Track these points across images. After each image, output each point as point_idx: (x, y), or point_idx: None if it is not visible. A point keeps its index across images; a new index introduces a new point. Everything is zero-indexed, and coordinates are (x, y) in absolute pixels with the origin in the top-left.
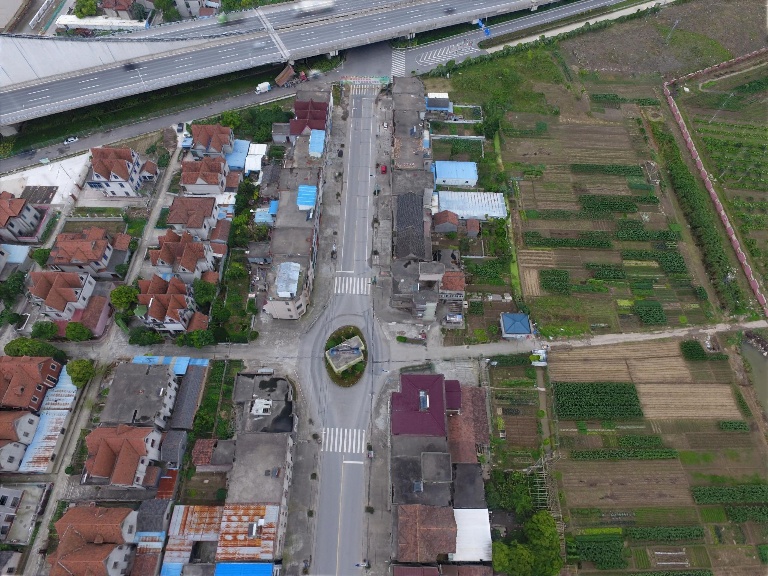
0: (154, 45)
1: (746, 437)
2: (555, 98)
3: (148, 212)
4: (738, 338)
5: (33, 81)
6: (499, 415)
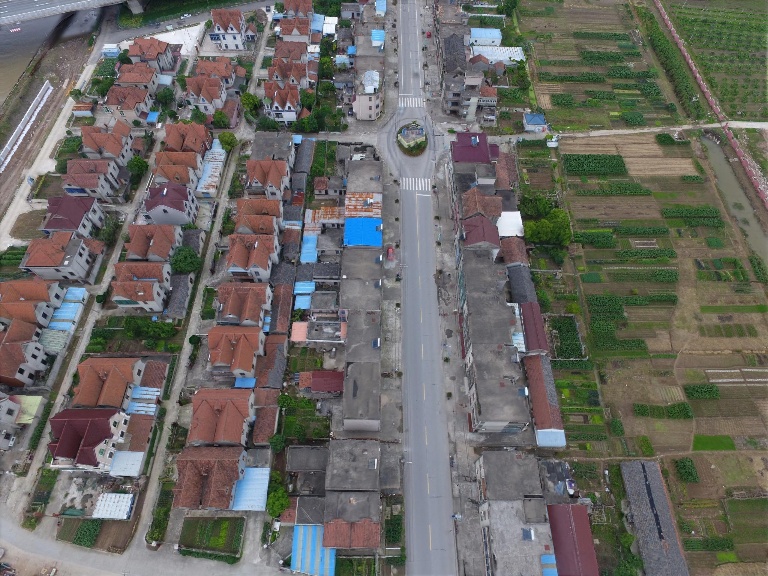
0: None
1: (701, 185)
2: None
3: (254, 59)
4: (698, 133)
5: None
6: (524, 172)
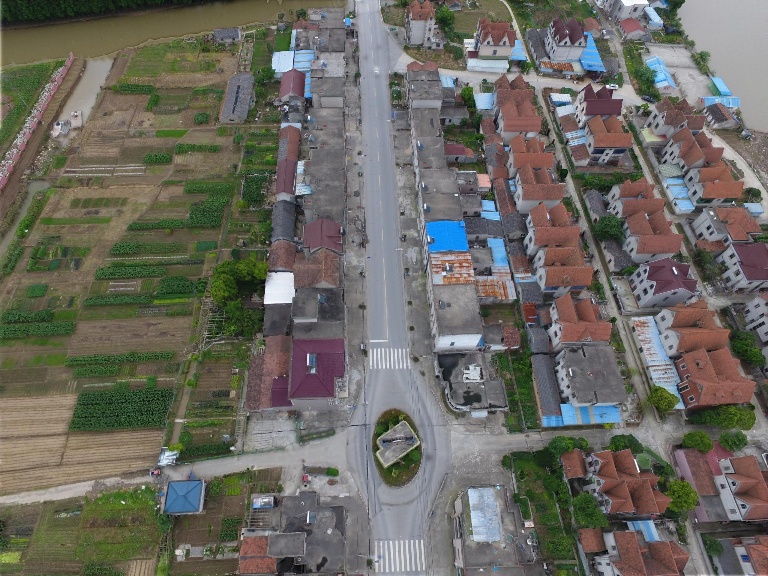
0: None
1: None
2: None
3: None
4: None
5: None
6: (234, 390)
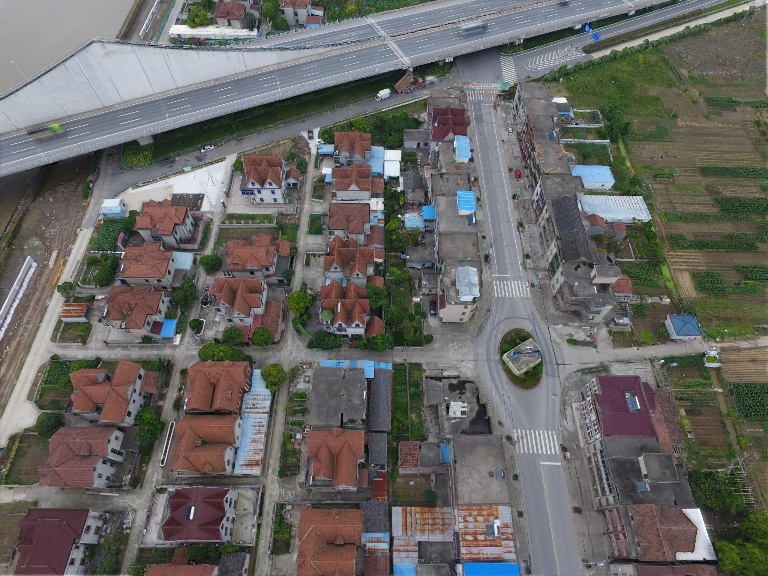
0: (283, 54)
1: None
2: (671, 101)
3: (298, 218)
4: None
5: (172, 91)
6: (683, 416)
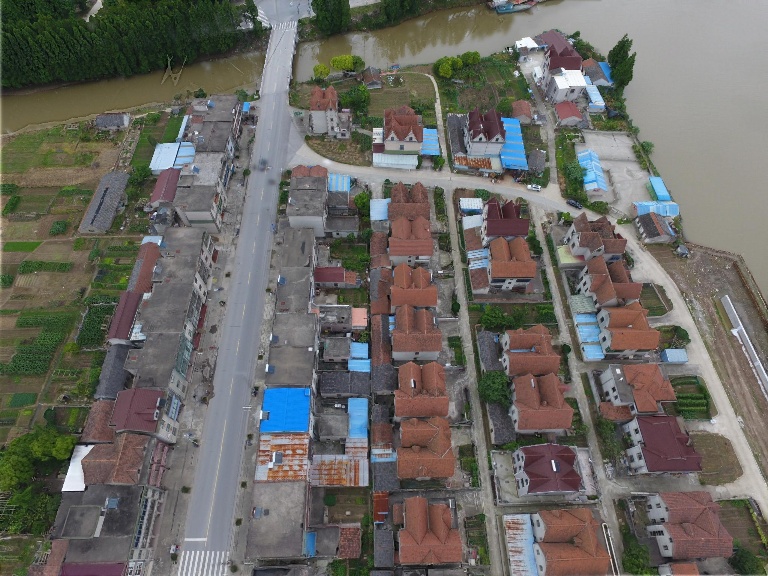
0: None
1: None
2: None
3: None
4: None
5: None
6: None
